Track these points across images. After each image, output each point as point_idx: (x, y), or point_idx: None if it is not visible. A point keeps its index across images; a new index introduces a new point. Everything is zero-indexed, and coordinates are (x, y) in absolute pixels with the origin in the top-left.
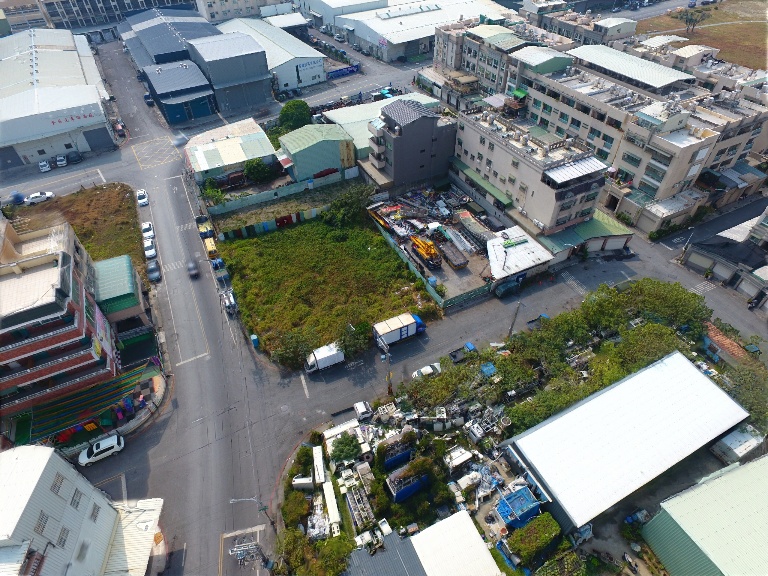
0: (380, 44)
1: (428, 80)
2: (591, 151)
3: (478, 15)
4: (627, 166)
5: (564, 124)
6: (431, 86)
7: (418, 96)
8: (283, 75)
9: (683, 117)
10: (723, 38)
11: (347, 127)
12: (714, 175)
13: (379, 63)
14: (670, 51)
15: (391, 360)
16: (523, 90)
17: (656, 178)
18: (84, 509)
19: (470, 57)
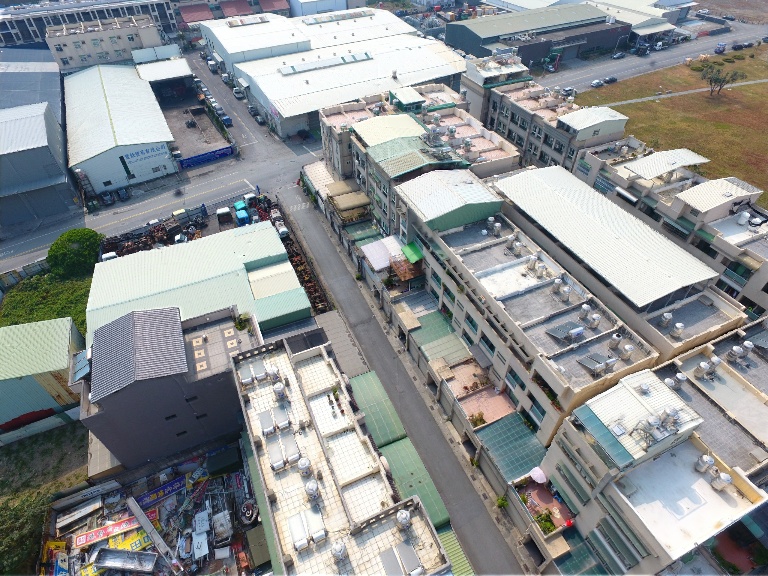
0: (272, 113)
1: (311, 185)
2: (445, 567)
3: (421, 69)
4: (565, 487)
5: (472, 333)
6: (314, 195)
7: (264, 233)
8: (99, 171)
9: (683, 432)
10: (761, 107)
11: (94, 318)
12: (748, 532)
13: (271, 139)
14: (677, 174)
15: None
16: (417, 248)
17: (618, 554)
18: None
19: (359, 166)
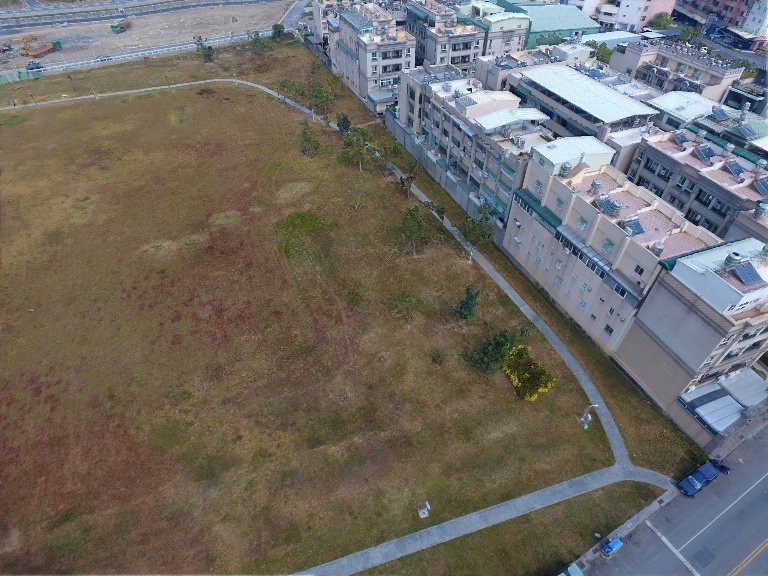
0: None
1: None
2: None
3: None
4: None
5: None
6: None
7: None
8: None
9: None
10: None
11: None
12: None
13: None
14: None
15: (696, 42)
16: None
17: None
18: (762, 15)
19: None
